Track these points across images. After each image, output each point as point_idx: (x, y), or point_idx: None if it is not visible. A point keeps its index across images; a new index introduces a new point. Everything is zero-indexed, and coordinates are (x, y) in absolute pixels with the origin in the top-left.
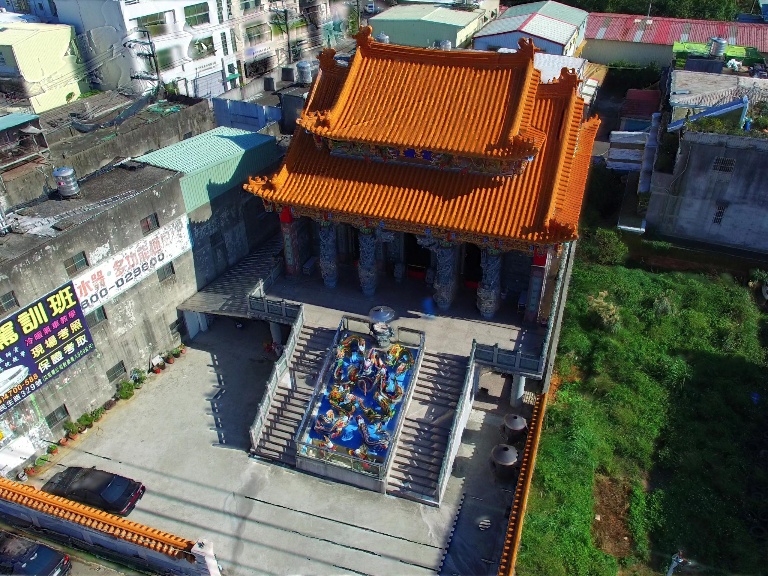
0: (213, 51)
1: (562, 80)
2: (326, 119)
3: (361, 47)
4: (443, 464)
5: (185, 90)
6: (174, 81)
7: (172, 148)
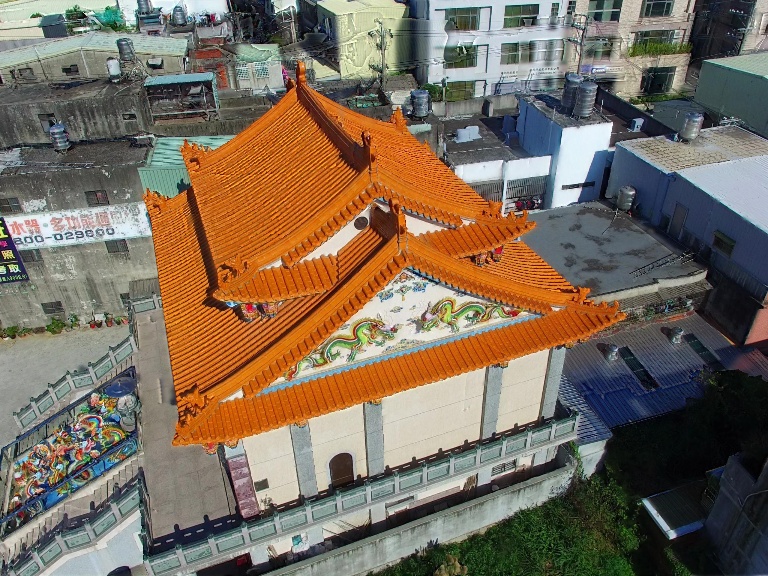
0: (471, 57)
1: (390, 216)
2: None
3: (298, 86)
4: (7, 574)
5: (483, 92)
6: (445, 79)
7: (205, 139)
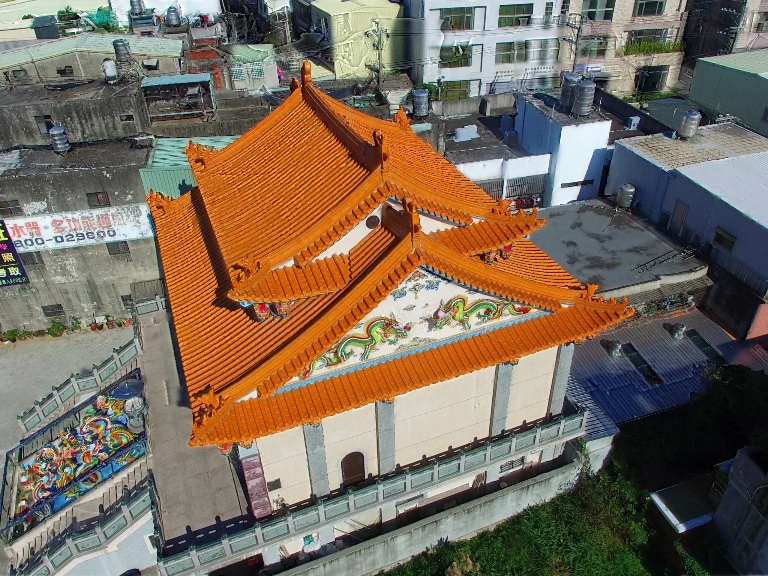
0: (467, 57)
1: (403, 214)
2: (201, 157)
3: (303, 86)
4: None
5: (478, 91)
6: (440, 79)
7: (205, 140)
